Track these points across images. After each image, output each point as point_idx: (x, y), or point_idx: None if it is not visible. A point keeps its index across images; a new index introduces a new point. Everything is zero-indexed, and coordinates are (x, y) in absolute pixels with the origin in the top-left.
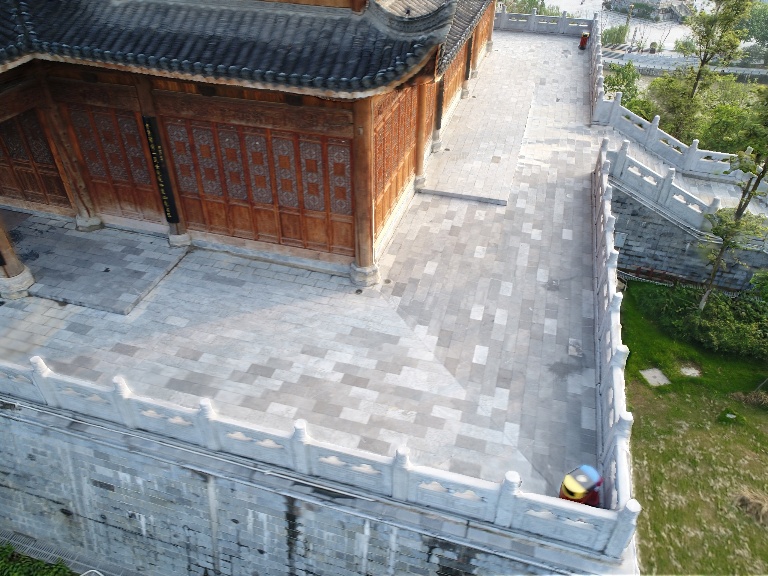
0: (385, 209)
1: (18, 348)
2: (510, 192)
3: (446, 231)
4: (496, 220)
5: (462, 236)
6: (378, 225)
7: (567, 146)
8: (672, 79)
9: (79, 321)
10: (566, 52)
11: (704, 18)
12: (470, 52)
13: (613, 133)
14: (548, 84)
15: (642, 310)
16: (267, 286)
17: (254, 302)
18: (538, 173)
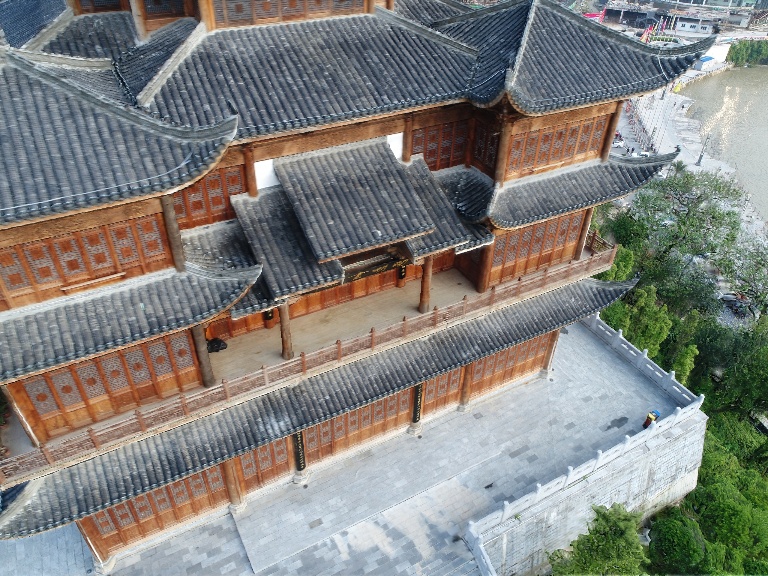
0: (149, 528)
1: None
2: (278, 563)
3: (190, 564)
4: None
5: None
6: (132, 538)
7: (396, 549)
8: (554, 558)
9: None
10: (619, 421)
11: None
12: (417, 406)
13: (459, 564)
14: (517, 458)
15: None
16: (70, 527)
17: (52, 534)
18: (326, 560)
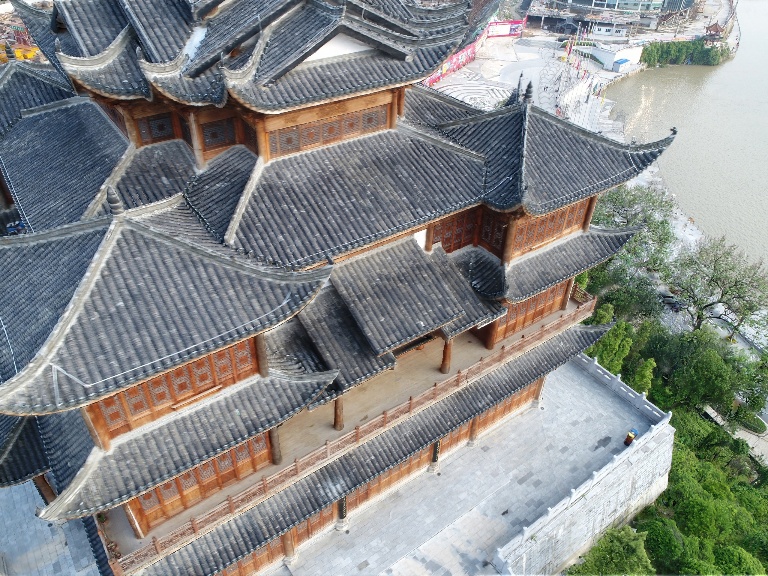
0: None
1: (31, 564)
2: None
3: None
4: None
5: None
6: None
7: None
8: (573, 573)
9: (61, 562)
10: (604, 441)
11: (609, 548)
12: (436, 448)
13: None
14: (525, 485)
15: None
16: None
17: None
18: None
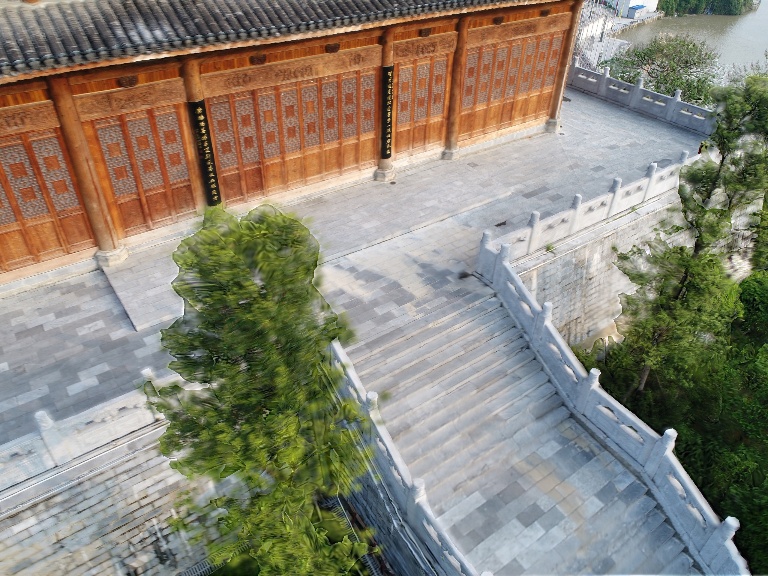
0: None
1: None
2: None
3: (23, 327)
4: (88, 343)
5: (21, 342)
6: None
7: (372, 290)
8: (627, 254)
9: None
10: (661, 162)
11: (707, 169)
12: (386, 124)
13: (474, 300)
14: (535, 198)
15: (253, 574)
16: None
17: None
18: None
